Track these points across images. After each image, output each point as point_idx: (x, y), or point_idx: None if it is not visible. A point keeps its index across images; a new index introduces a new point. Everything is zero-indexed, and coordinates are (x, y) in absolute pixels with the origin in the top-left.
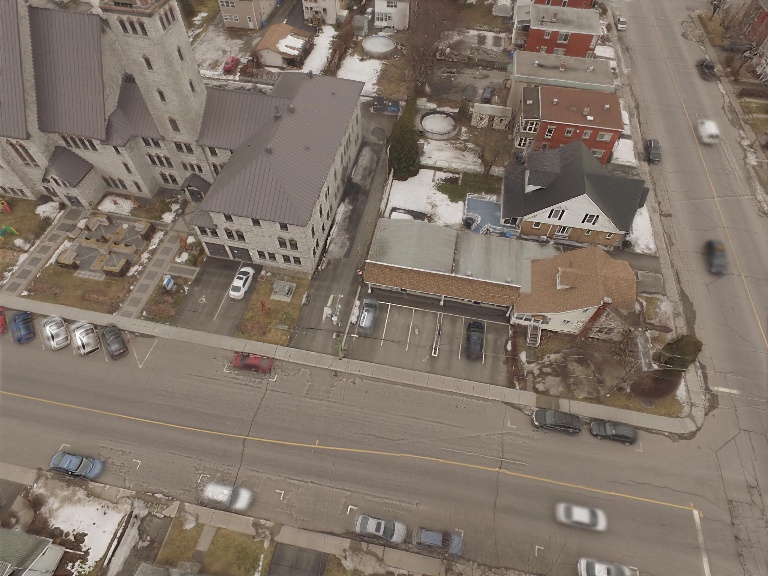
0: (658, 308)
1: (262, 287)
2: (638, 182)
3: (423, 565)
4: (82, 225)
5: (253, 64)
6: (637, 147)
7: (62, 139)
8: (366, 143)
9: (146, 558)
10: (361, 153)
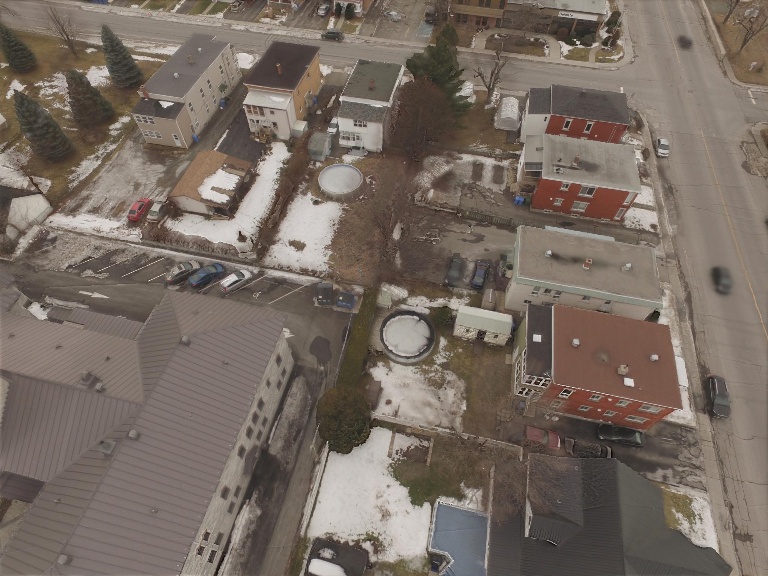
0: None
1: None
2: None
3: None
4: None
5: (170, 208)
6: (692, 383)
7: None
8: (300, 369)
9: None
10: (290, 390)
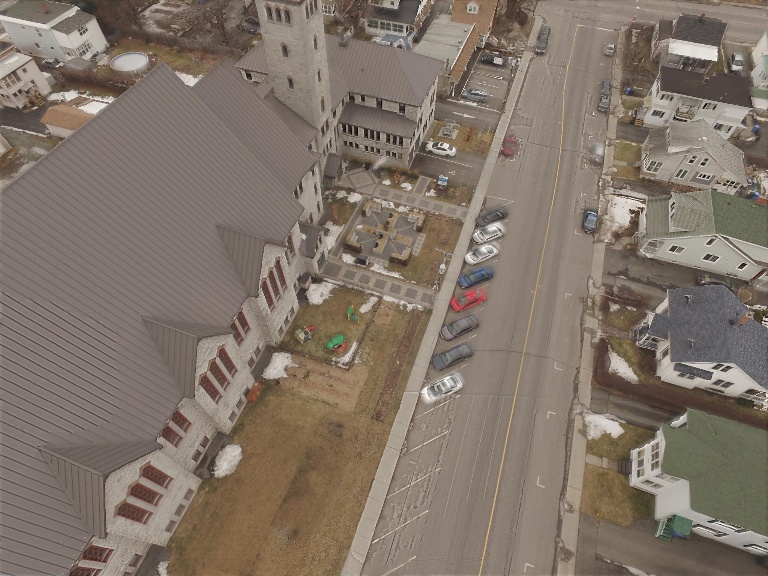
0: None
1: None
2: None
3: (616, 94)
4: (351, 259)
5: None
6: None
7: None
8: None
9: (635, 185)
10: None
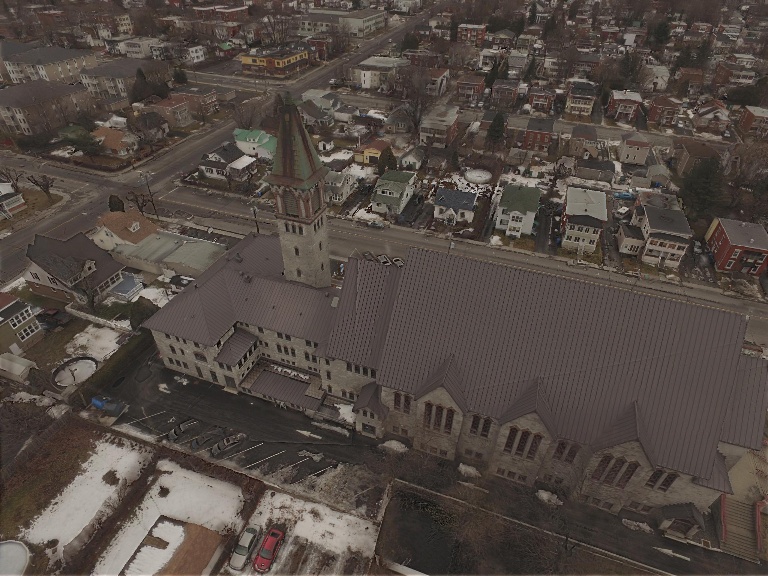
0: None
1: None
2: None
3: None
4: None
5: None
6: None
7: None
8: None
9: (346, 208)
10: None
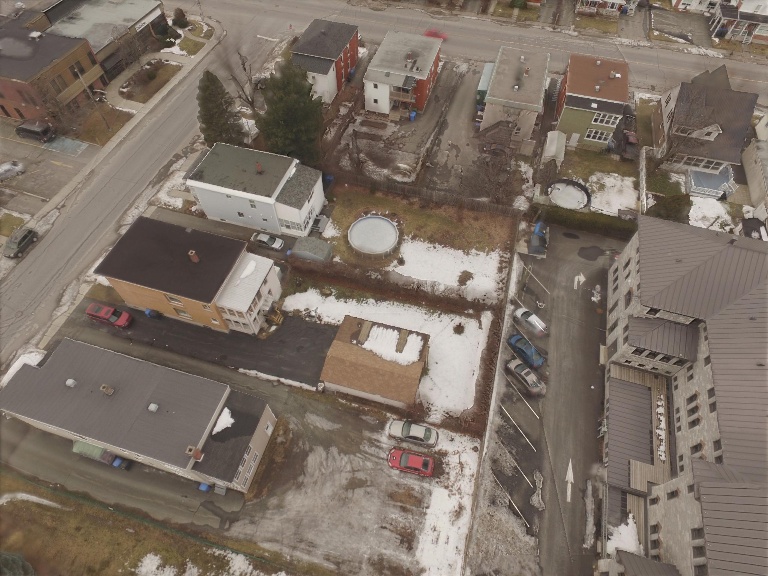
0: (760, 116)
1: None
2: None
3: None
4: None
5: None
6: None
7: None
8: None
9: None
10: None
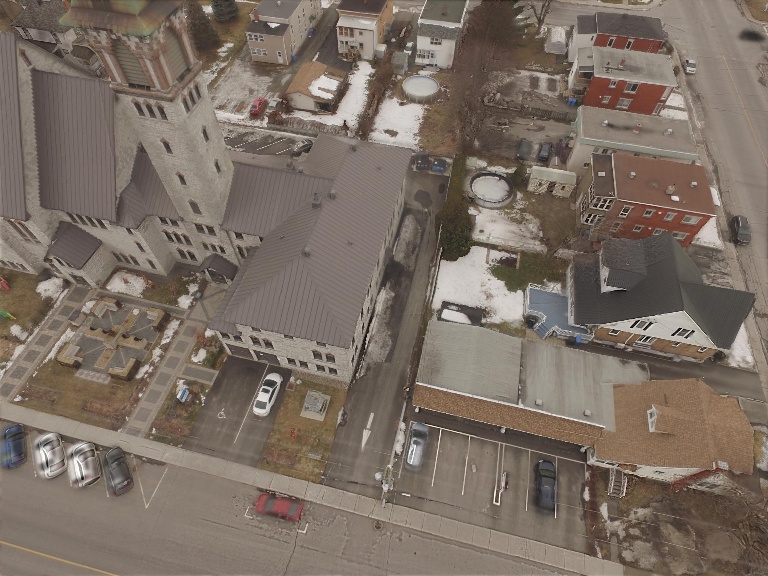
0: (764, 446)
1: (291, 399)
2: (746, 295)
3: None
4: (87, 309)
5: (282, 107)
6: (720, 223)
7: (67, 215)
8: (409, 210)
9: None
10: (403, 223)
